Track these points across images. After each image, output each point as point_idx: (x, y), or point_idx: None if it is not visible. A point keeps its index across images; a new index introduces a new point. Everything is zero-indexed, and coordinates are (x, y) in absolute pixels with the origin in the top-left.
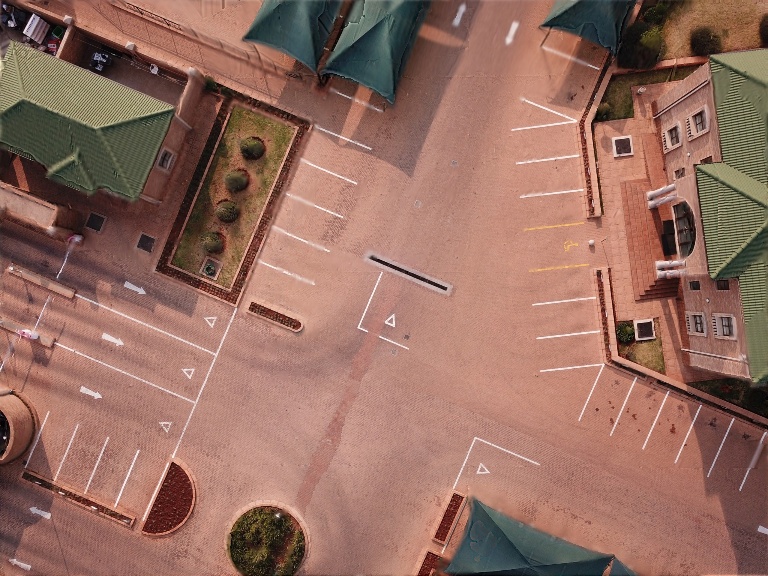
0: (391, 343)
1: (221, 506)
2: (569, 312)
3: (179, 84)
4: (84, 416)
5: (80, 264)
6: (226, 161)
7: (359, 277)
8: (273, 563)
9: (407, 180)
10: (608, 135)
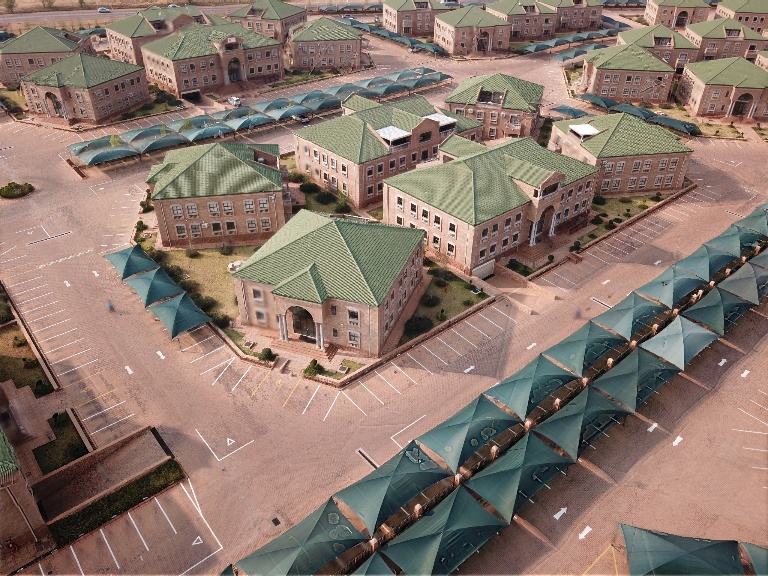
0: (7, 158)
1: None
2: None
3: None
4: None
5: None
6: None
7: None
8: None
9: None
10: None
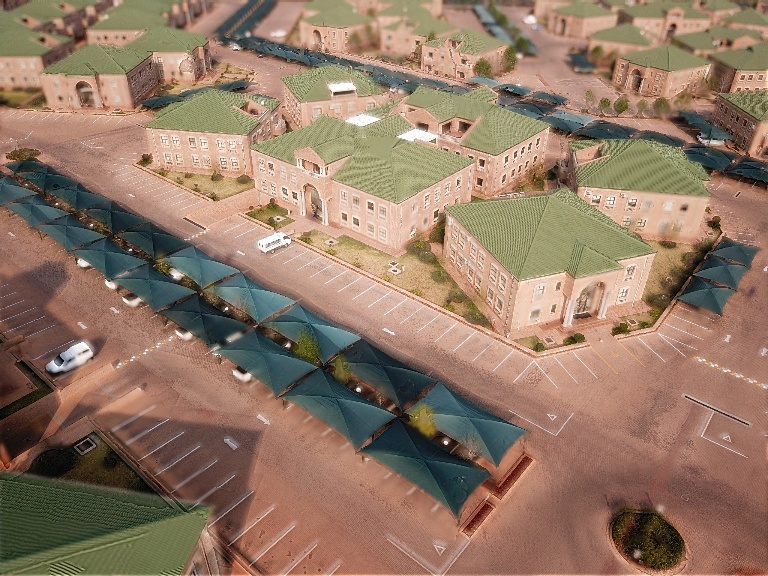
0: None
1: None
2: None
3: None
4: None
5: None
6: None
7: None
8: (642, 527)
9: None
10: None
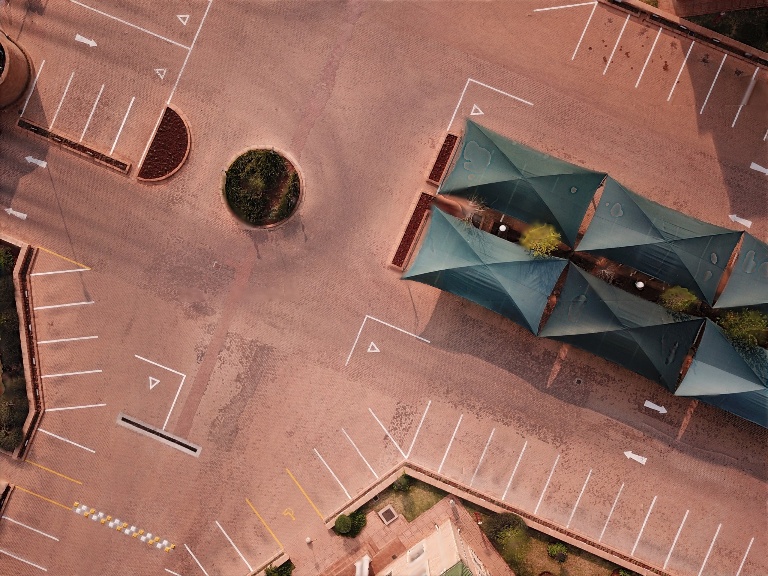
0: None
1: (216, 152)
2: None
3: None
4: (79, 64)
5: None
6: None
7: None
8: (268, 205)
9: None
10: None
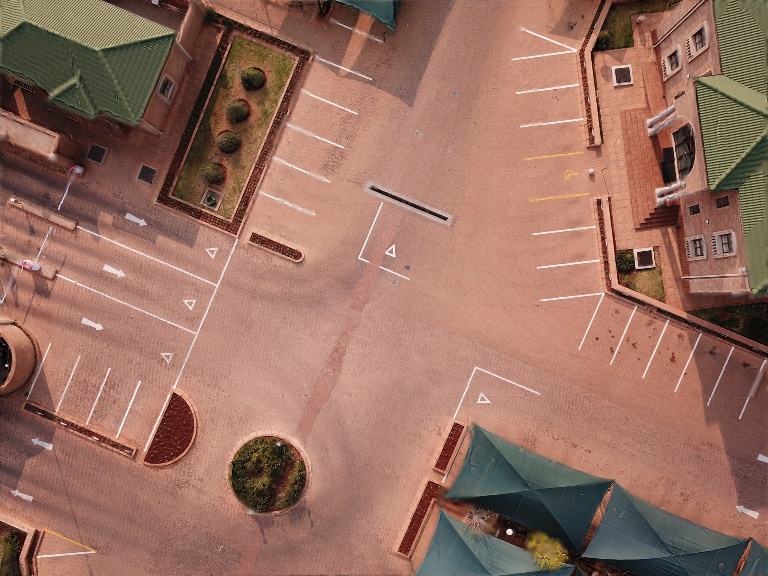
0: (392, 273)
1: (222, 436)
2: (569, 241)
3: (180, 12)
4: (86, 347)
5: (81, 196)
6: (227, 92)
7: (360, 207)
8: (274, 493)
9: (407, 110)
10: (608, 64)
